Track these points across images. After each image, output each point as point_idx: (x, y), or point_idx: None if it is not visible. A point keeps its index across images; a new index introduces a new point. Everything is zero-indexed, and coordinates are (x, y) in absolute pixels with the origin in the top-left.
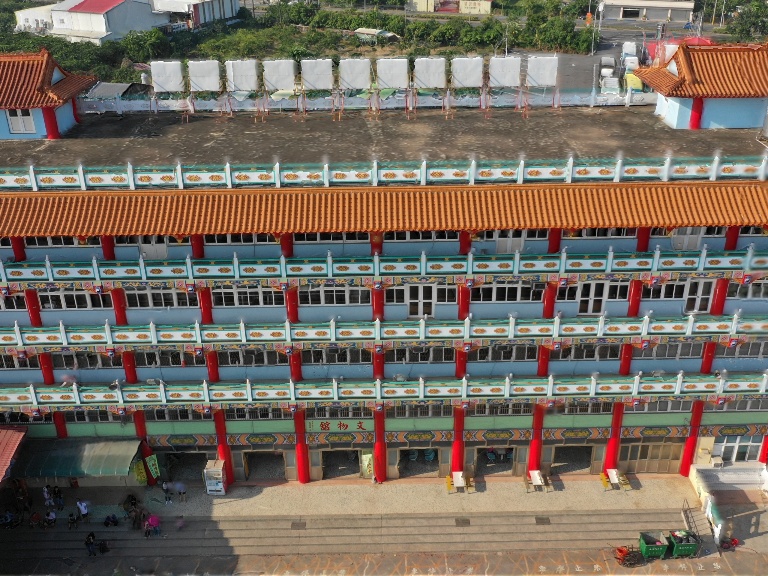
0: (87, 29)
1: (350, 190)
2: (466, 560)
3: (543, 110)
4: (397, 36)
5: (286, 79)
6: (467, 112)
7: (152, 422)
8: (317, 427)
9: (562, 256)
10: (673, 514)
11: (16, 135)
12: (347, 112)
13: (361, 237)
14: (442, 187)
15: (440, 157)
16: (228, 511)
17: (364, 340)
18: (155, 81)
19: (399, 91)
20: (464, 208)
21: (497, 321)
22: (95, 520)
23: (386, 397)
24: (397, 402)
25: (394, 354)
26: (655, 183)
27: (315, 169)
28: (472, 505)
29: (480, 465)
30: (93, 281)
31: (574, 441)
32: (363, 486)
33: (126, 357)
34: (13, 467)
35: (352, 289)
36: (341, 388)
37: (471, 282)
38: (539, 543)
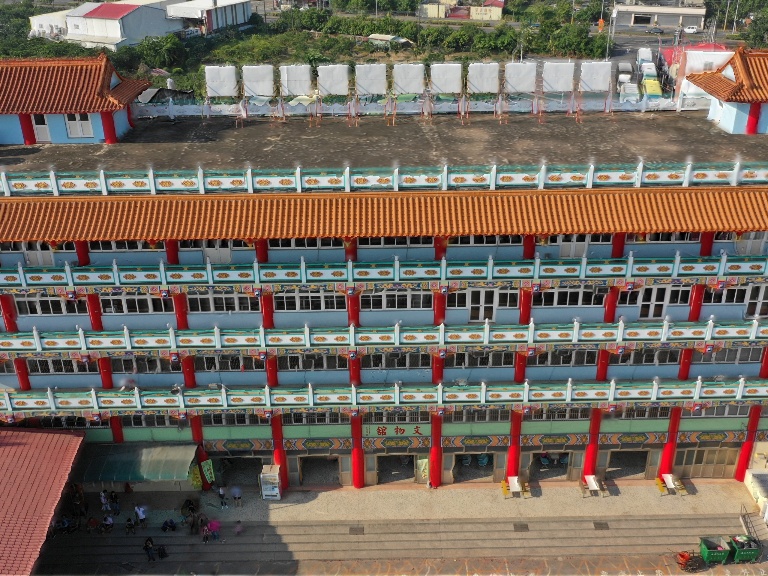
0: (102, 35)
1: (420, 194)
2: (527, 565)
3: (595, 115)
4: (410, 42)
5: (340, 84)
6: (519, 117)
7: (209, 427)
8: (374, 432)
9: (629, 260)
10: (731, 519)
11: (74, 139)
12: (399, 117)
13: (425, 241)
14: (512, 191)
15: (503, 162)
16: (285, 516)
17: (428, 344)
18: (209, 86)
19: (420, 97)
20: (534, 212)
21: (558, 325)
22: (152, 525)
23: (447, 402)
24: (459, 407)
25: (453, 359)
26: (724, 188)
27: (380, 173)
28: (529, 510)
29: (534, 470)
30: (160, 285)
31: (630, 446)
32: (418, 491)
33: (185, 361)
34: (72, 472)
35: (414, 293)
36: (403, 393)
37: (538, 286)
38: (599, 548)
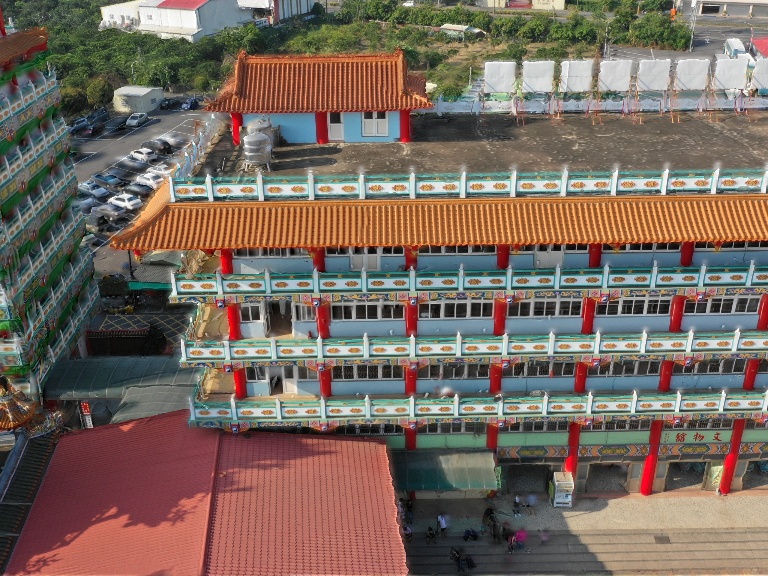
0: (176, 25)
1: None
2: None
3: None
4: (483, 32)
5: (622, 80)
6: None
7: (505, 433)
8: (672, 438)
9: None
10: None
11: (368, 138)
12: None
13: (764, 244)
14: None
15: None
16: (584, 525)
17: (767, 351)
18: (487, 82)
19: None
20: None
21: None
22: (451, 534)
23: None
24: None
25: (767, 364)
26: None
27: None
28: None
29: None
30: (505, 290)
31: None
32: (709, 498)
33: (494, 367)
34: None
35: (741, 297)
36: (728, 399)
37: None
38: None
